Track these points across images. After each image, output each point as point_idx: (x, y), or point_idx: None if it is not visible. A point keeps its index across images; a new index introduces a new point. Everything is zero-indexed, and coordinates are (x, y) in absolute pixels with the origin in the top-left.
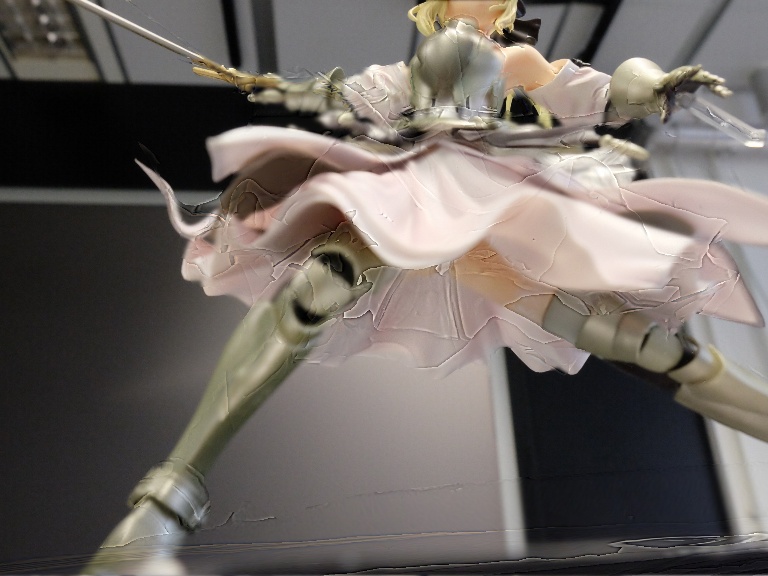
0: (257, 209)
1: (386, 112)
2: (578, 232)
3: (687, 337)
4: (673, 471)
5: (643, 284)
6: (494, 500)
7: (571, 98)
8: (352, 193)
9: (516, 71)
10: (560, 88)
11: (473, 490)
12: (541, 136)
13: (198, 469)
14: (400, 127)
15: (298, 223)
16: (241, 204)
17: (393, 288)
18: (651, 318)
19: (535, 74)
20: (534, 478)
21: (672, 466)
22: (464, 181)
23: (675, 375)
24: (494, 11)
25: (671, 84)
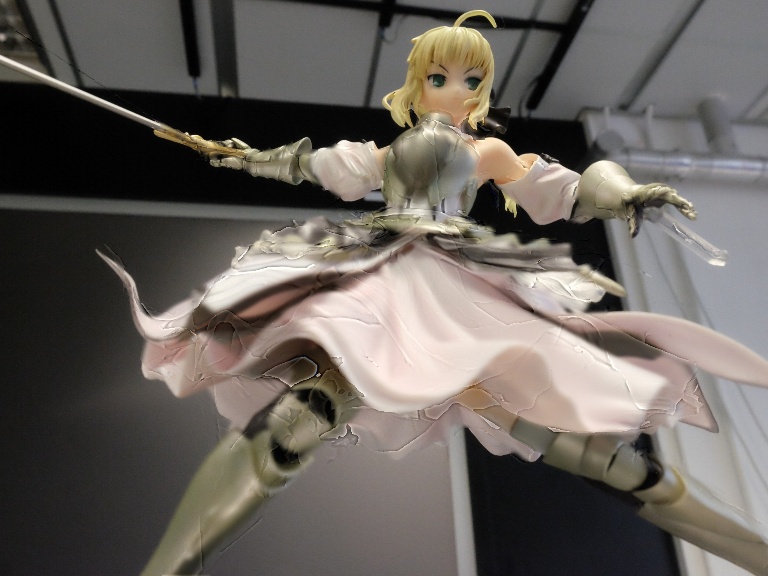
0: (234, 338)
1: (368, 232)
2: (562, 384)
3: (651, 457)
4: None
5: (619, 426)
6: None
7: (540, 194)
8: (336, 331)
9: (488, 165)
10: (530, 184)
11: None
12: (519, 258)
13: None
14: (378, 236)
15: (277, 352)
16: None
17: None
18: (618, 439)
19: (506, 169)
20: None
21: None
22: (441, 297)
23: (639, 495)
24: (468, 105)
25: (640, 198)
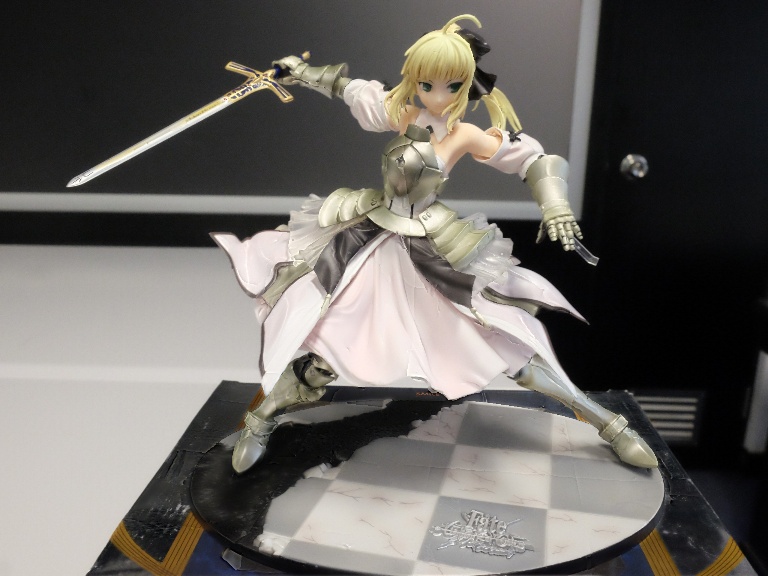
0: None
1: None
2: (418, 383)
3: None
4: (350, 573)
5: None
6: (310, 570)
7: (504, 165)
8: None
9: (463, 150)
10: (495, 162)
11: (306, 567)
12: None
13: (269, 420)
14: None
15: None
16: None
17: None
18: None
19: (478, 150)
20: (320, 567)
21: (351, 572)
22: (394, 288)
23: None
24: None
25: None
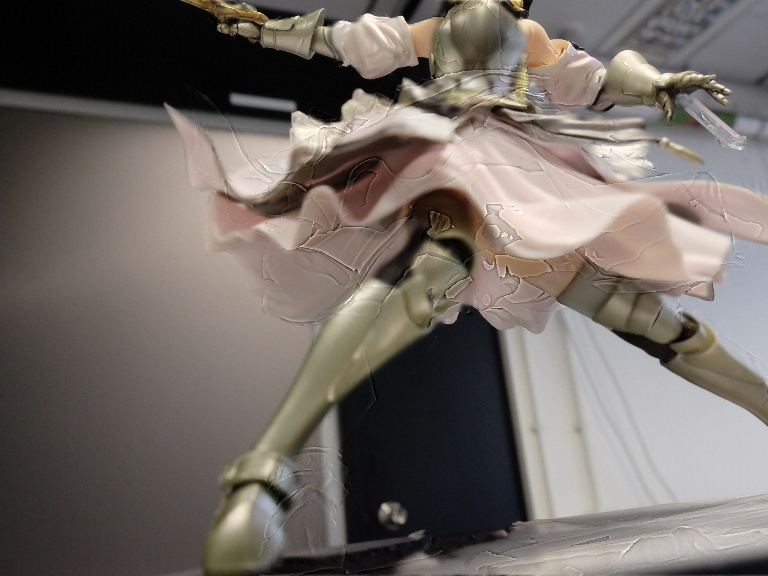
0: (372, 188)
1: None
2: (677, 235)
3: (686, 314)
4: None
5: (699, 277)
6: None
7: (567, 79)
8: (480, 182)
9: None
10: (561, 69)
11: None
12: (598, 129)
13: None
14: None
15: None
16: (335, 177)
17: (381, 248)
18: (663, 298)
19: (540, 52)
20: None
21: None
22: None
23: (676, 346)
24: None
25: (674, 84)
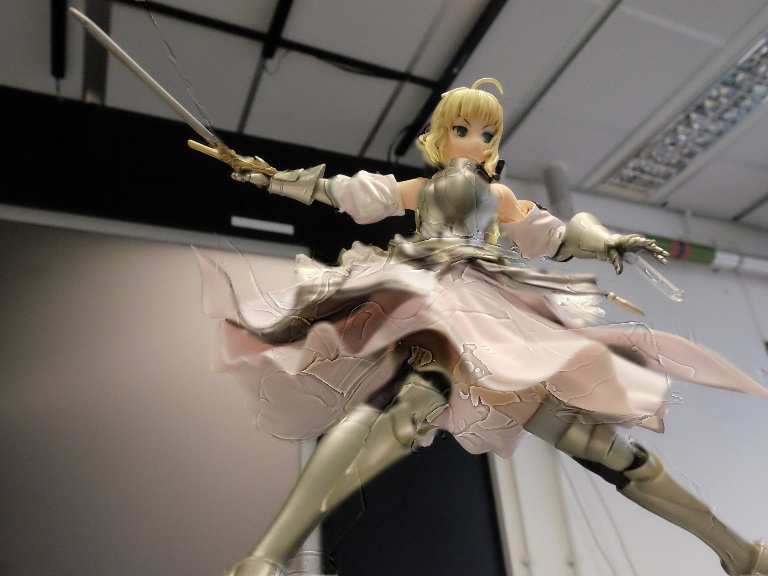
0: (368, 326)
1: None
2: (621, 375)
3: (637, 444)
4: None
5: (644, 412)
6: None
7: (533, 234)
8: (458, 325)
9: None
10: (527, 225)
11: None
12: (557, 281)
13: None
14: None
15: None
16: (336, 314)
17: (366, 374)
18: (616, 429)
19: (509, 211)
20: None
21: None
22: None
23: (629, 474)
24: (485, 155)
25: (622, 244)
